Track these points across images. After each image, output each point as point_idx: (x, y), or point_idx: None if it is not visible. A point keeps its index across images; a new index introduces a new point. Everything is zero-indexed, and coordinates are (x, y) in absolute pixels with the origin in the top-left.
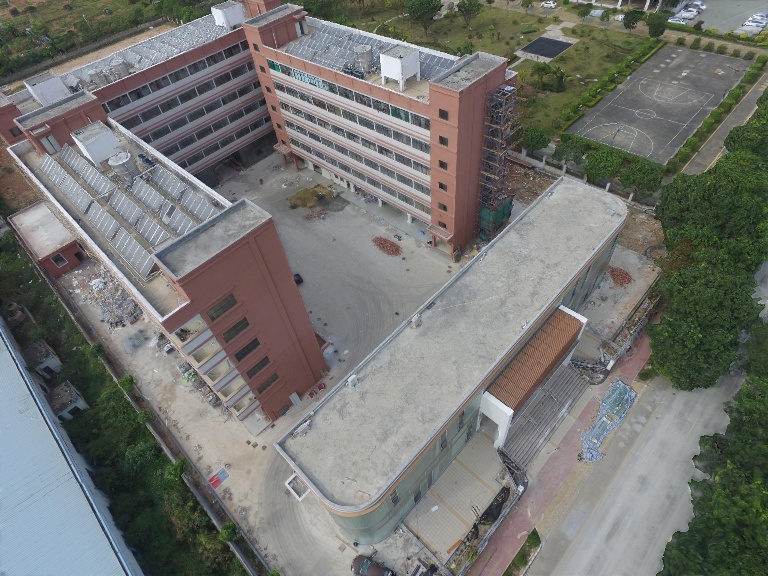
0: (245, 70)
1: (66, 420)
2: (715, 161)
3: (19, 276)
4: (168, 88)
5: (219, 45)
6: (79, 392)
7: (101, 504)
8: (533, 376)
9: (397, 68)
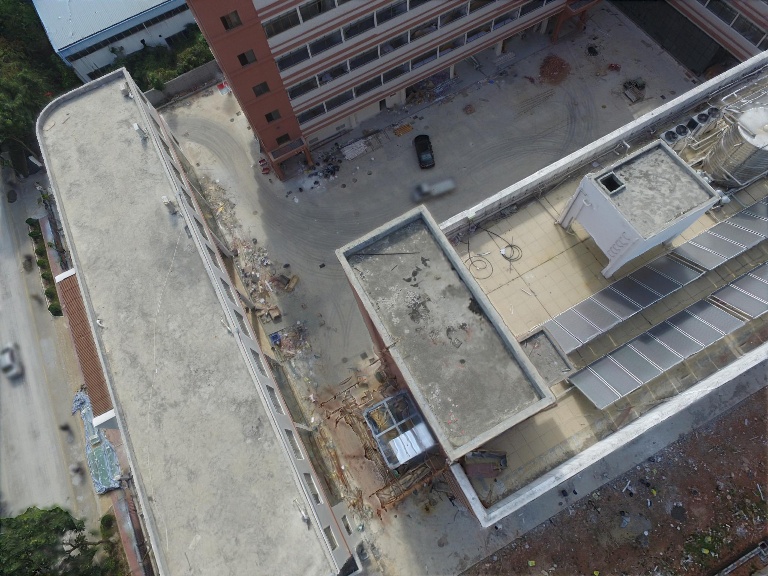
0: None
1: None
2: None
3: None
4: None
5: None
6: None
7: None
8: (74, 320)
9: None
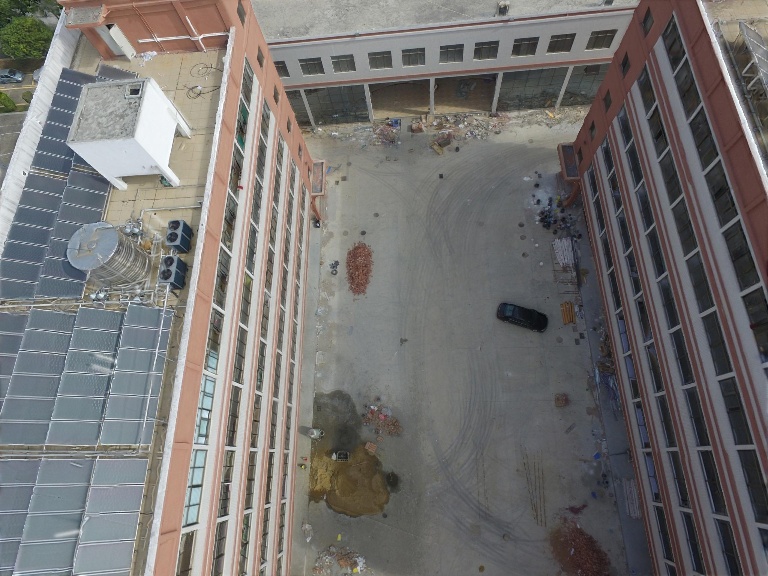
0: None
1: None
2: (1, 89)
3: None
4: None
5: None
6: None
7: None
8: None
9: (160, 106)
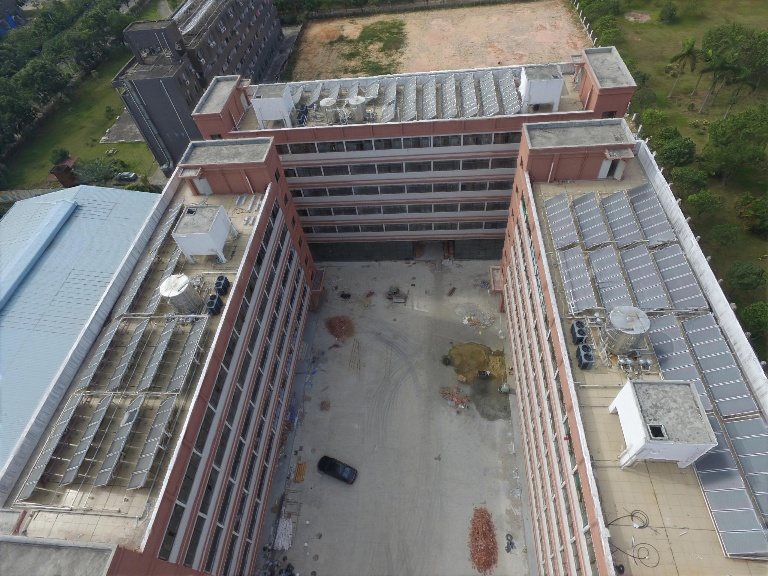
0: (515, 164)
1: None
2: None
3: None
4: (397, 151)
5: (492, 126)
6: None
7: None
8: None
9: (636, 437)
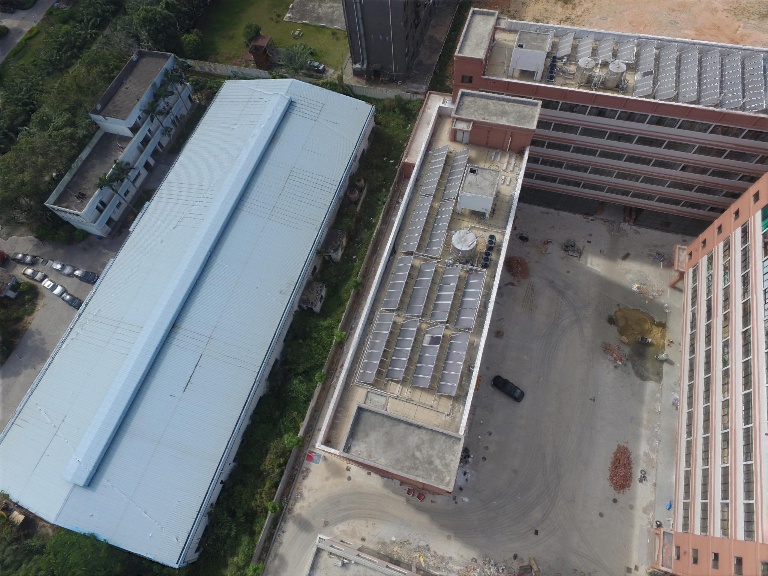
0: (751, 159)
1: (302, 307)
2: None
3: (392, 147)
4: (637, 124)
5: (751, 122)
6: (325, 294)
7: (258, 395)
8: None
9: None
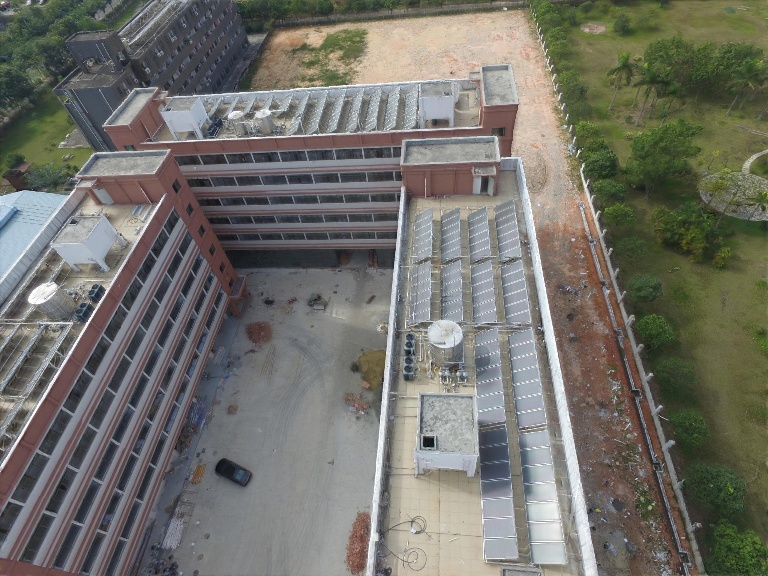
0: None
1: None
2: None
3: None
4: (303, 163)
5: (389, 140)
6: None
7: None
8: None
9: None
